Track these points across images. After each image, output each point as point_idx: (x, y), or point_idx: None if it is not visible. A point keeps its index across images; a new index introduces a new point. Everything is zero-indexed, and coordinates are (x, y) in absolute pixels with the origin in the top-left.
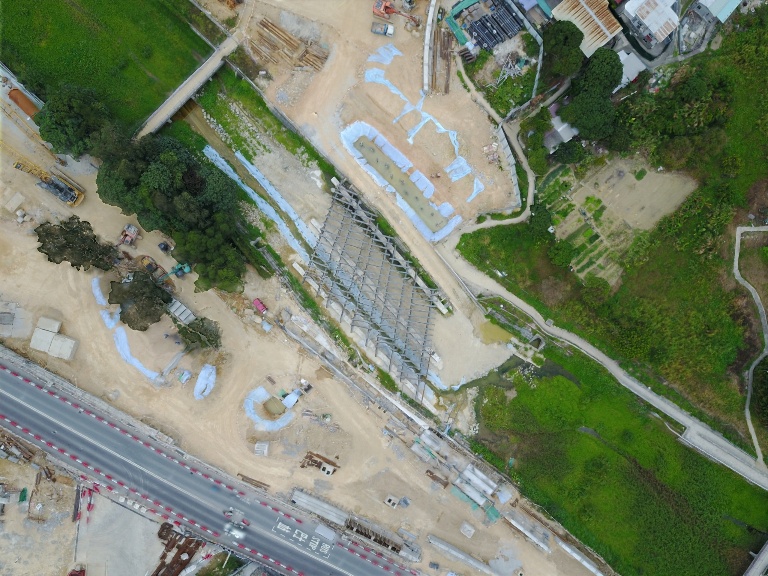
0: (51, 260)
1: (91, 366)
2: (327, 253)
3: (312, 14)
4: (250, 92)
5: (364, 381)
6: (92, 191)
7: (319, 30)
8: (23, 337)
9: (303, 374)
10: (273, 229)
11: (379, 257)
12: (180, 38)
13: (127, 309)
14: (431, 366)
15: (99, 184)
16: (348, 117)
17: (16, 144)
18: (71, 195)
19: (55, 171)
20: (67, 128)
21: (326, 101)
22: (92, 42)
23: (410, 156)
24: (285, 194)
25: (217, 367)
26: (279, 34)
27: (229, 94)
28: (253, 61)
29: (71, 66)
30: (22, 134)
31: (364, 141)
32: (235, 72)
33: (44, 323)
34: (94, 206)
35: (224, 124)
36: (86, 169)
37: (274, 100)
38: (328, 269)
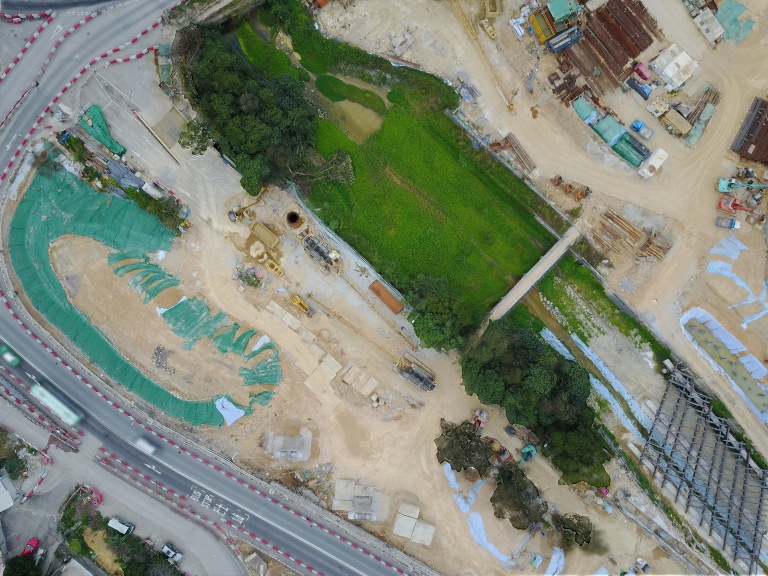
0: (452, 468)
1: (446, 549)
2: (663, 434)
3: (658, 207)
4: (588, 277)
5: (695, 559)
6: (440, 375)
7: (664, 222)
8: (380, 520)
9: (640, 553)
10: (607, 409)
11: (711, 437)
12: (519, 224)
13: (513, 510)
14: (762, 545)
15: (469, 379)
16: (686, 303)
17: (370, 330)
18: (431, 384)
19: (410, 358)
20: (445, 328)
21: (666, 289)
22: (439, 230)
23: (744, 340)
24: (619, 375)
25: (564, 549)
26: (624, 225)
27: (564, 277)
28: (595, 249)
29: (419, 253)
30: (376, 321)
31: (694, 323)
32: (576, 259)
33: (406, 509)
34: (442, 389)
35: (561, 307)
36: (435, 354)
37: (616, 288)
38: (663, 450)
